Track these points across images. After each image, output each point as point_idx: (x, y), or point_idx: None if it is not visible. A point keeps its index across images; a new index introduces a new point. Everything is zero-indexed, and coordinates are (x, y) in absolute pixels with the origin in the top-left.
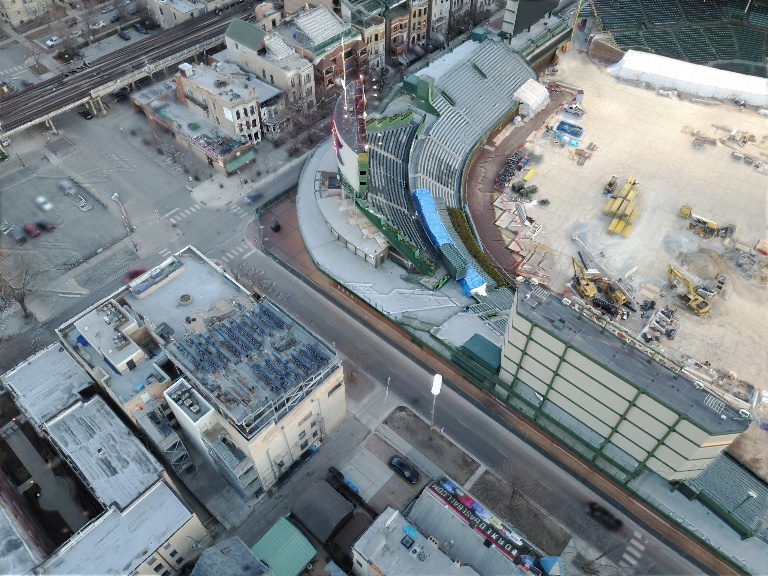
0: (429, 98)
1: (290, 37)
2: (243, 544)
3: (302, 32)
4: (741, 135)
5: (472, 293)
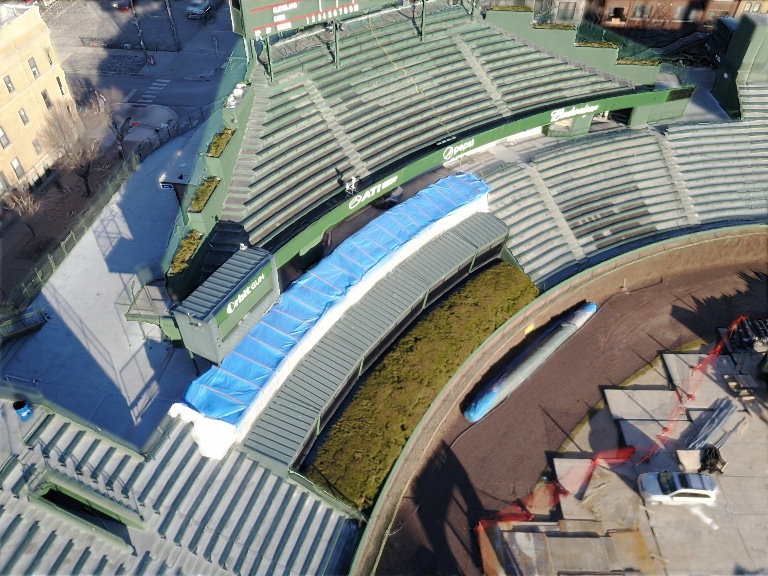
0: (742, 70)
1: None
2: None
3: None
4: None
5: None
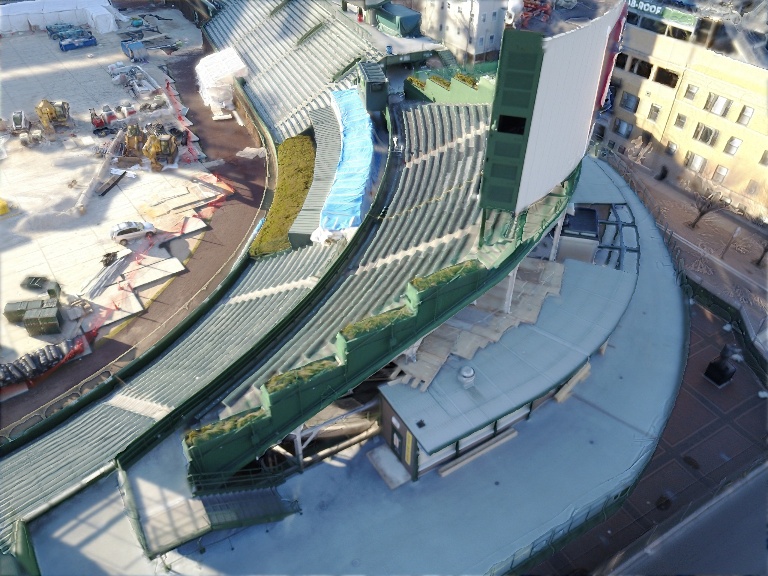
0: None
1: None
2: None
3: None
4: None
5: None
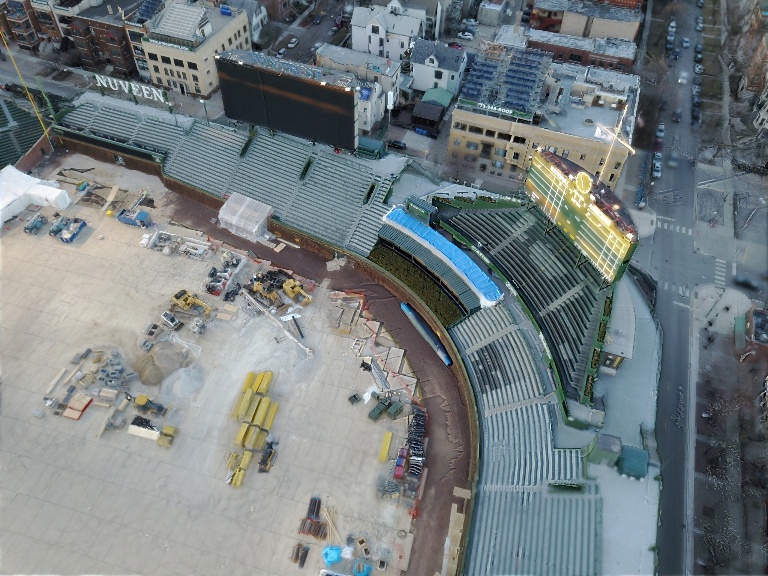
0: None
1: None
2: (453, 71)
3: None
4: None
5: (395, 206)
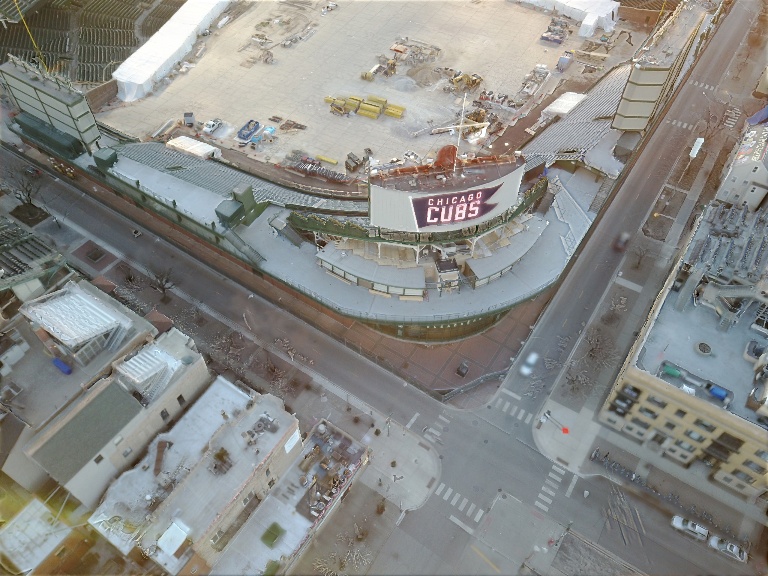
0: None
1: (64, 382)
2: None
3: (91, 342)
4: (258, 38)
5: None
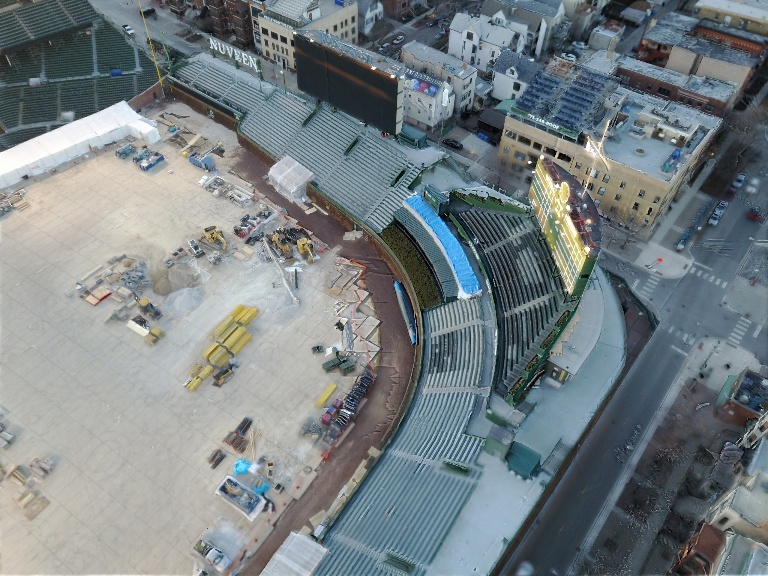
0: None
1: None
2: None
3: None
4: None
5: None
